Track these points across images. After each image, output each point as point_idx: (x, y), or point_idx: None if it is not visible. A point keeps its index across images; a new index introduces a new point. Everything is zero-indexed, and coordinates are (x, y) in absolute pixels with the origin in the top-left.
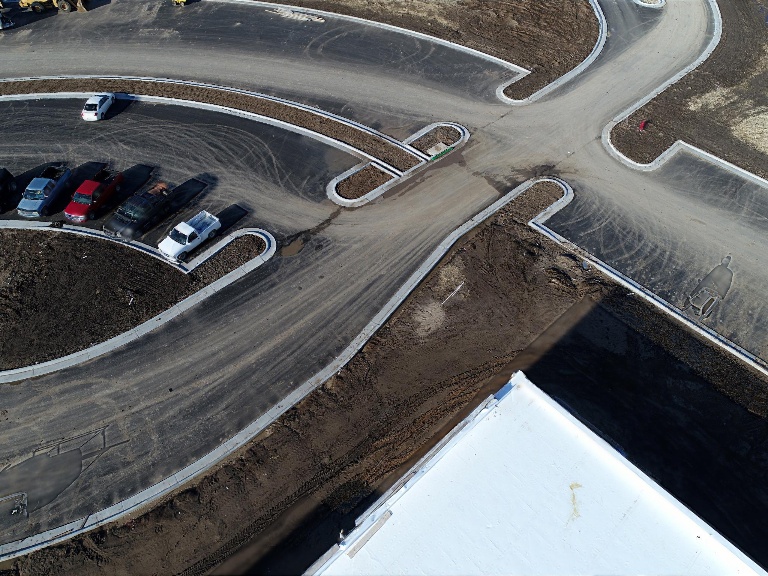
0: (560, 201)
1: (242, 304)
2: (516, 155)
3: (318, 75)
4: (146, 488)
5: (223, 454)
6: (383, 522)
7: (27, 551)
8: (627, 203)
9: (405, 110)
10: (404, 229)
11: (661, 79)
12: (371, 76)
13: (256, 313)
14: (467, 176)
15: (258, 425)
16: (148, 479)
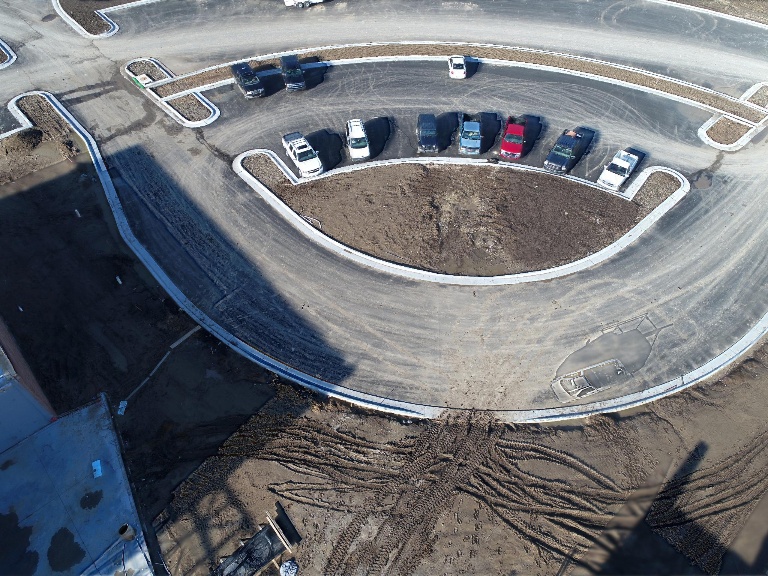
0: None
1: (691, 225)
2: None
3: (627, 42)
4: (713, 358)
5: (760, 334)
6: None
7: (653, 399)
8: None
9: (724, 72)
10: None
11: None
12: (675, 44)
13: (708, 232)
14: None
15: None
16: (710, 352)
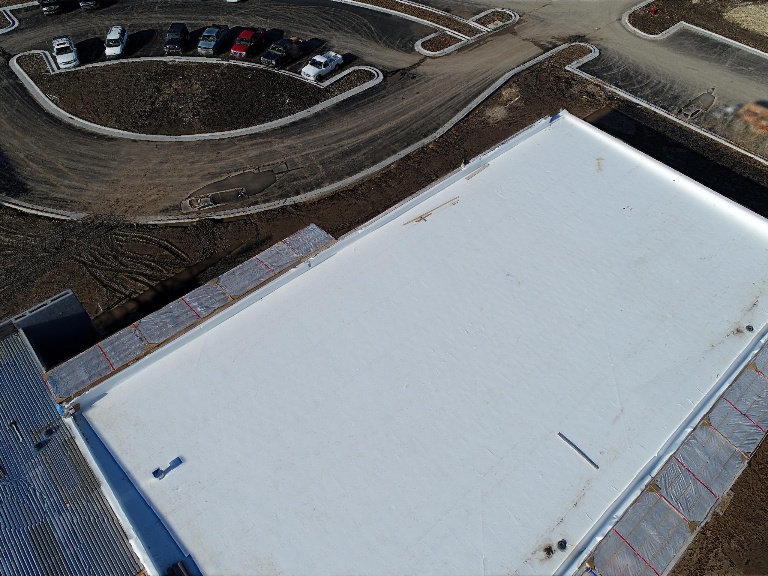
0: (589, 56)
1: (364, 105)
2: (555, 29)
3: None
4: (320, 188)
5: (366, 174)
6: (484, 167)
7: (254, 211)
8: (639, 58)
9: (469, 1)
10: (474, 69)
11: None
12: None
13: (375, 110)
14: (519, 41)
15: (386, 162)
16: (320, 184)
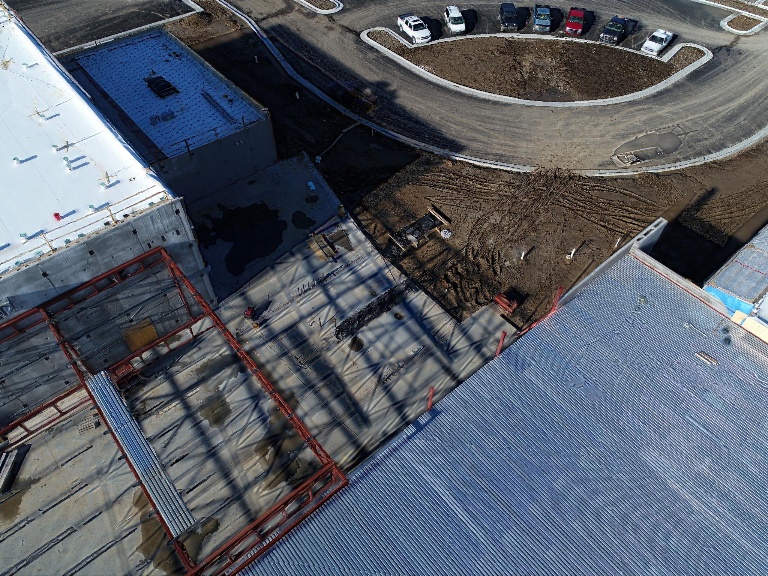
0: None
1: (713, 78)
2: None
3: None
4: None
5: (762, 136)
6: None
7: (683, 166)
8: None
9: None
10: None
11: None
12: None
13: (726, 82)
14: None
15: None
16: (724, 145)
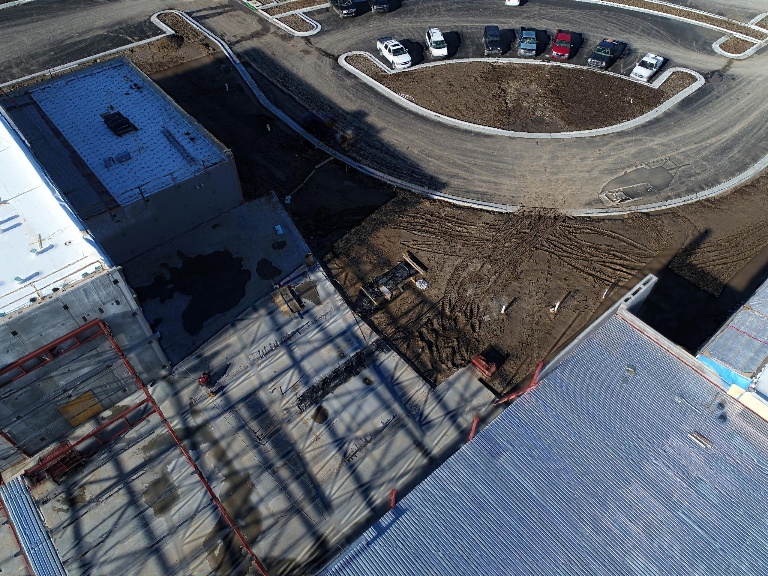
0: None
1: (705, 105)
2: None
3: None
4: None
5: (757, 171)
6: None
7: (675, 205)
8: None
9: (736, 5)
10: None
11: None
12: None
13: (719, 110)
14: None
15: (767, 160)
16: (718, 180)
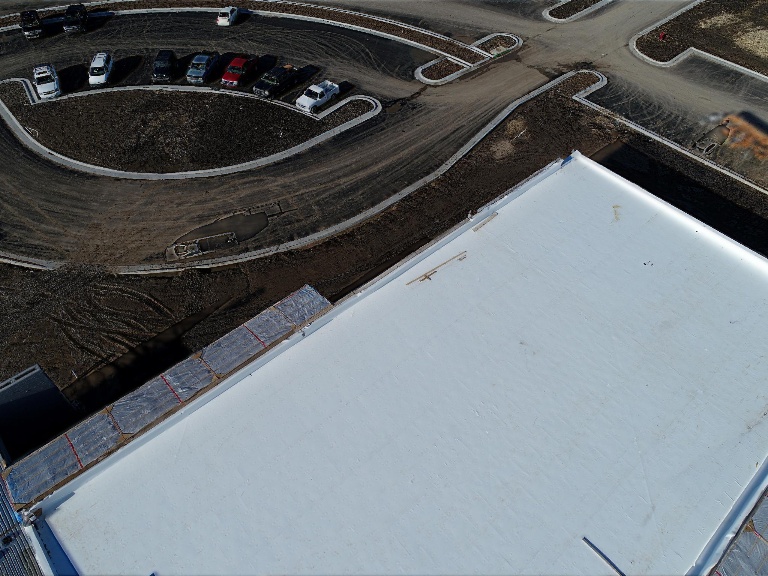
0: (597, 84)
1: (362, 139)
2: (561, 55)
3: None
4: (315, 233)
5: (365, 217)
6: (493, 217)
7: (244, 259)
8: (649, 87)
9: (470, 24)
10: (477, 99)
11: (678, 7)
12: (440, 1)
13: (373, 144)
14: (523, 68)
15: (386, 203)
16: (315, 228)
